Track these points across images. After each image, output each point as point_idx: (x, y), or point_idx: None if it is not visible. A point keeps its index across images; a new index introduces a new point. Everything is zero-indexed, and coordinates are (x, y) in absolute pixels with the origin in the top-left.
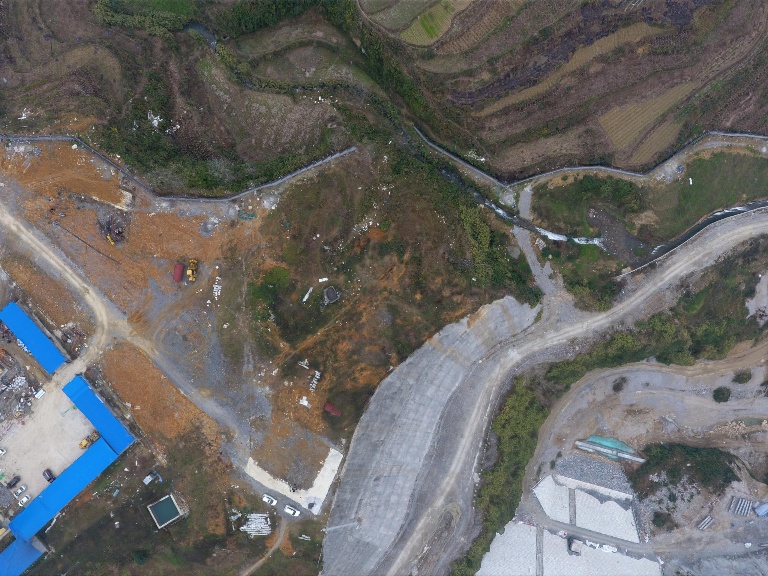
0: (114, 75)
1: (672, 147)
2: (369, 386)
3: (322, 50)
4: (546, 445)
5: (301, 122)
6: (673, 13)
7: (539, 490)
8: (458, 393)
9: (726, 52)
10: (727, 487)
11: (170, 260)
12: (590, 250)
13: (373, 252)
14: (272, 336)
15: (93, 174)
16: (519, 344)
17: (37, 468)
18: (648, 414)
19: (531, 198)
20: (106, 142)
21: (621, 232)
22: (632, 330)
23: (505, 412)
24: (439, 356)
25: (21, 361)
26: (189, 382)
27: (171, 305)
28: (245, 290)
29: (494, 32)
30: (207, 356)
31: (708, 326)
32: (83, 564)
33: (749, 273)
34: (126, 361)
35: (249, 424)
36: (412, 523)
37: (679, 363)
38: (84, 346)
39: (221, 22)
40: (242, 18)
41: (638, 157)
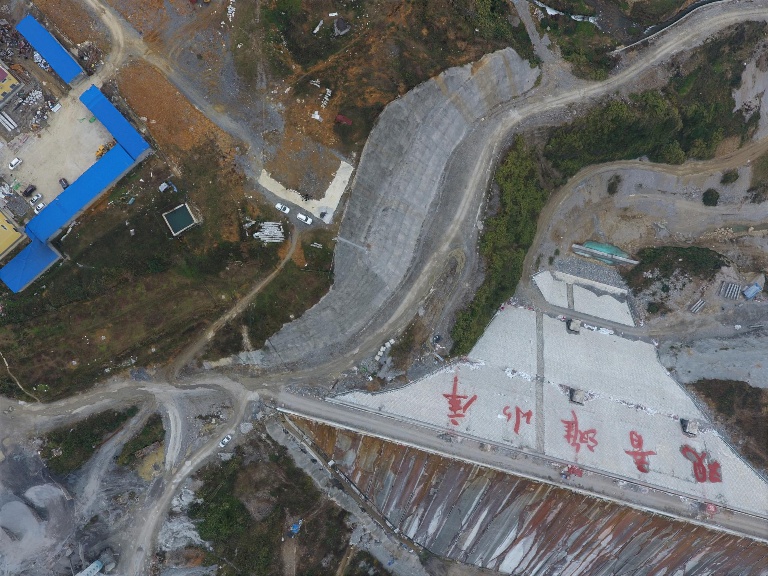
0: None
1: None
2: (378, 103)
3: None
4: (545, 237)
5: None
6: None
7: (538, 279)
8: (462, 147)
9: None
10: (717, 273)
11: None
12: (586, 26)
13: None
14: (284, 57)
15: None
16: (520, 106)
17: (53, 179)
18: (641, 219)
19: None
20: None
21: (615, 12)
22: (626, 102)
23: (507, 165)
24: (444, 100)
25: (38, 77)
26: (204, 98)
27: (186, 25)
28: (258, 12)
29: None
30: (221, 74)
31: (697, 107)
32: (98, 270)
33: (735, 61)
34: (142, 77)
35: (262, 138)
36: (418, 266)
37: (670, 159)
38: (100, 63)
39: None
40: None
41: None
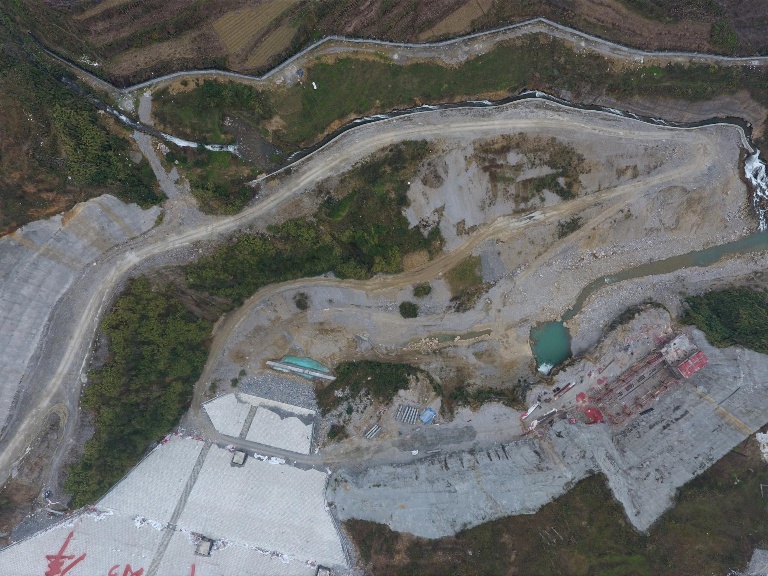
0: None
1: (285, 50)
2: None
3: None
4: (220, 361)
5: None
6: None
7: (212, 406)
8: (69, 295)
9: None
10: (395, 396)
11: None
12: (221, 156)
13: None
14: None
15: None
16: (138, 247)
17: None
18: (340, 332)
19: (152, 103)
20: None
21: (257, 139)
22: (264, 234)
23: (116, 313)
24: (31, 254)
25: None
26: None
27: None
28: None
29: None
30: None
31: (353, 232)
32: None
33: (398, 181)
34: None
35: None
36: (14, 424)
37: (352, 276)
38: None
39: None
40: None
41: (253, 60)
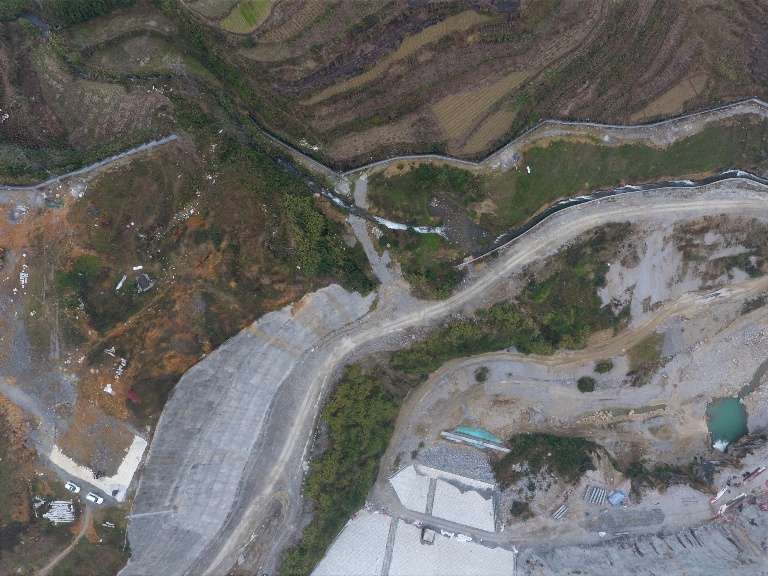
0: None
1: (505, 135)
2: (175, 373)
3: (157, 39)
4: (404, 435)
5: (134, 111)
6: (500, 1)
7: (396, 480)
8: (289, 382)
9: (560, 40)
10: (582, 476)
11: None
12: (430, 239)
13: (189, 240)
14: (79, 324)
15: None
16: (353, 333)
17: None
18: (514, 404)
19: (367, 187)
20: None
21: (463, 221)
22: (472, 319)
23: (336, 400)
24: (262, 344)
25: None
26: None
27: None
28: (52, 278)
29: (317, 20)
30: (13, 344)
31: (554, 315)
32: None
33: (598, 262)
34: None
35: (54, 412)
36: (239, 511)
37: (537, 353)
38: None
39: (48, 11)
40: (69, 7)
41: (472, 145)
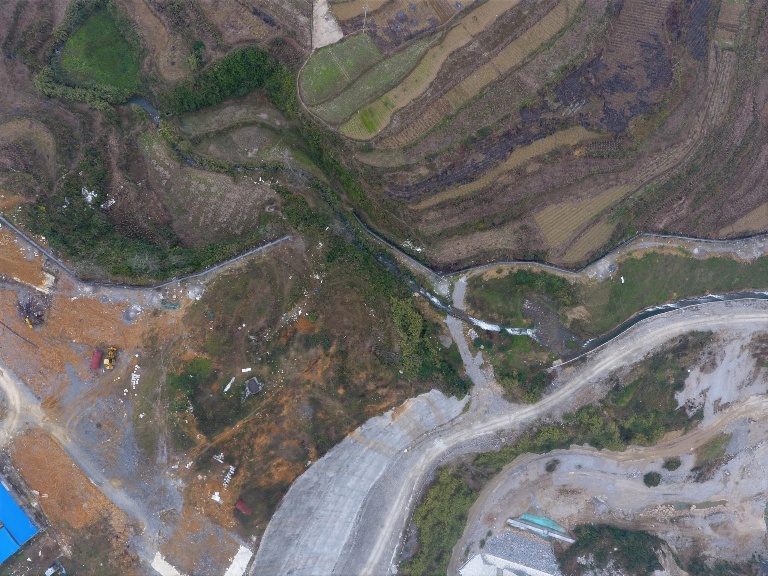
0: (48, 150)
1: (604, 248)
2: (283, 483)
3: (266, 131)
4: (475, 525)
5: (240, 202)
6: (609, 120)
7: (466, 571)
8: (381, 482)
9: (661, 158)
10: (650, 575)
11: (89, 346)
12: (522, 341)
13: (299, 344)
14: (189, 428)
15: (16, 254)
16: (446, 434)
17: None
18: (580, 495)
19: (465, 289)
20: (31, 223)
21: (554, 324)
22: (559, 422)
23: (427, 503)
24: (361, 448)
25: None
26: (100, 472)
27: (87, 392)
28: (164, 380)
29: (433, 129)
30: (121, 446)
31: (636, 419)
32: None
33: (678, 368)
34: (37, 447)
35: (159, 517)
36: None
37: (610, 449)
38: None
39: (163, 100)
40: (184, 98)
41: (571, 255)
